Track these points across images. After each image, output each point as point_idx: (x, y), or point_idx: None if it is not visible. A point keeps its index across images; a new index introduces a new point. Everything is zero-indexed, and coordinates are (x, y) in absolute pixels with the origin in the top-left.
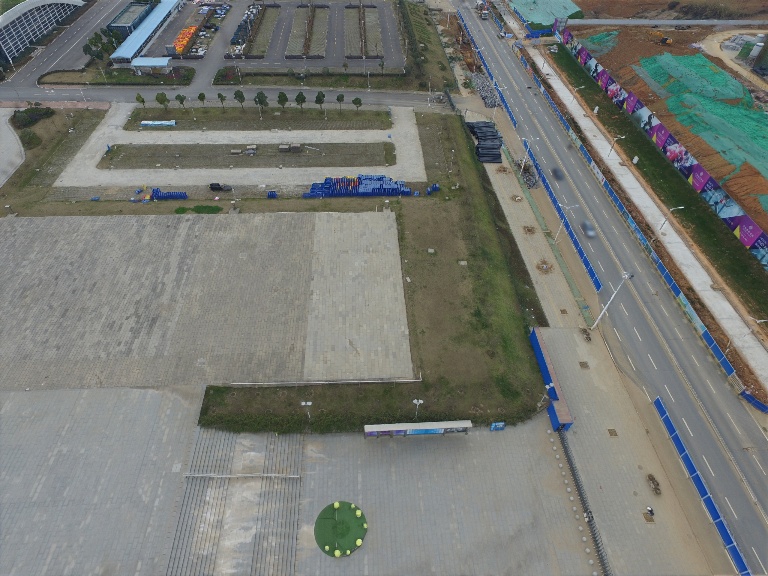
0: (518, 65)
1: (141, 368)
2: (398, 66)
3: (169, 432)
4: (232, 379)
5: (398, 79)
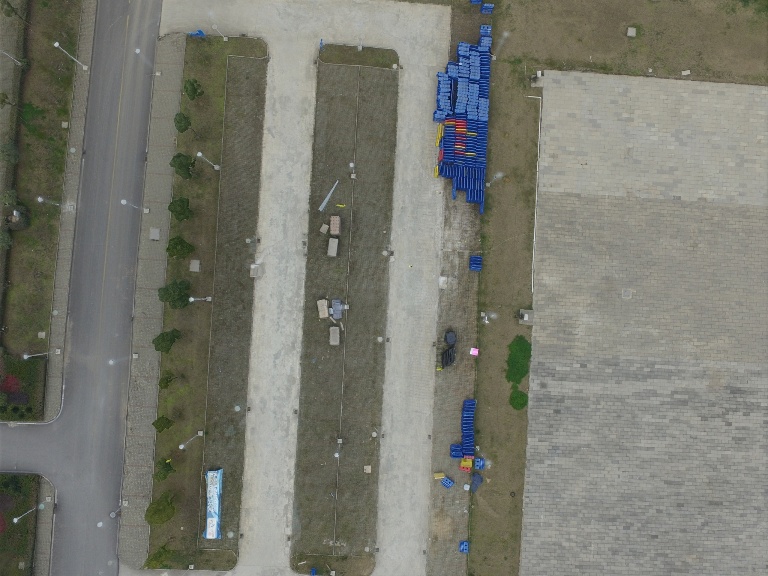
0: None
1: None
2: None
3: None
4: None
5: None
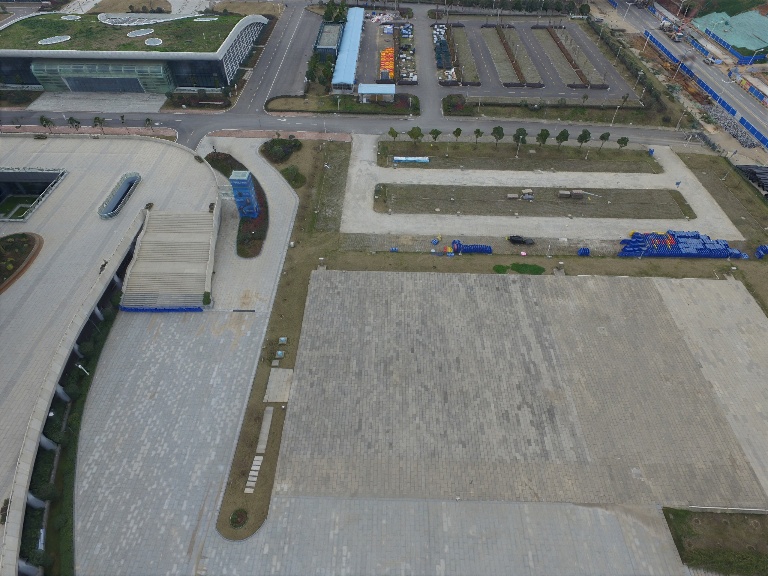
0: (748, 96)
1: (572, 477)
2: (631, 97)
3: (655, 572)
4: (687, 500)
5: (639, 113)
